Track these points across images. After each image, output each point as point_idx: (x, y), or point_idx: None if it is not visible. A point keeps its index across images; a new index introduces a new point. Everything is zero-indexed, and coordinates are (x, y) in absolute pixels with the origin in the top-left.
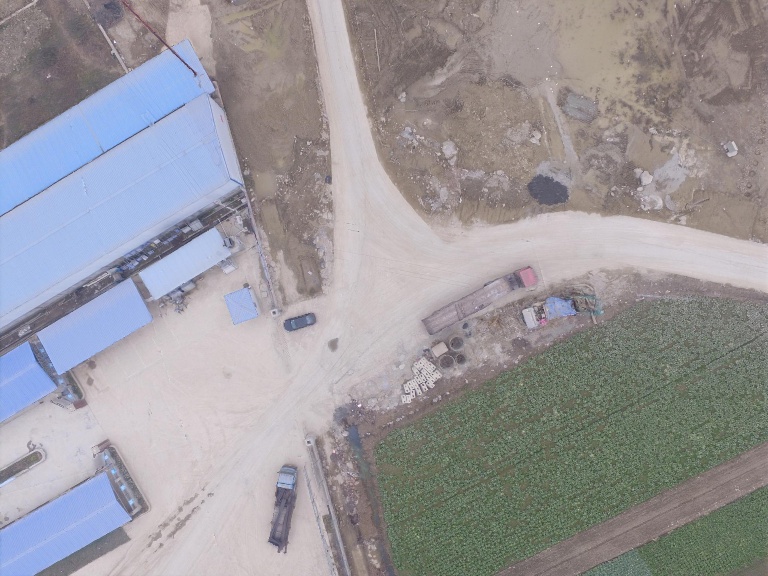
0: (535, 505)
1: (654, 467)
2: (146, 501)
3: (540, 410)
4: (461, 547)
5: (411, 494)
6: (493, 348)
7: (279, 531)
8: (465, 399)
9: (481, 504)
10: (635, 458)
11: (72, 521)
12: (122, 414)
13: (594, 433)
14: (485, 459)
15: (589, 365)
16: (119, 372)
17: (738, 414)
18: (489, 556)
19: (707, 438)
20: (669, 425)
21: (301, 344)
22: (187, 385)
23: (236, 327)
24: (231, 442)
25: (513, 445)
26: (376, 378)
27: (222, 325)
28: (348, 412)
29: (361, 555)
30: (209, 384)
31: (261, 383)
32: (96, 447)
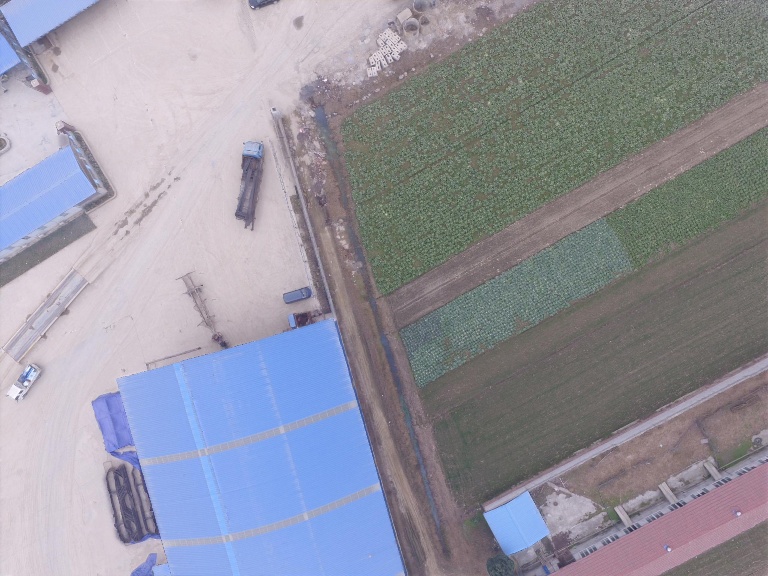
0: (502, 176)
1: (619, 132)
2: (112, 186)
3: (505, 80)
4: (429, 223)
5: (378, 170)
6: (457, 17)
7: (246, 206)
8: (431, 72)
9: (448, 177)
10: (600, 124)
11: (35, 192)
12: (87, 100)
13: (559, 101)
14: (451, 131)
15: (553, 32)
16: (84, 58)
17: (701, 74)
18: (457, 231)
19: (671, 100)
20: (633, 89)
21: (266, 23)
22: (153, 68)
23: (201, 8)
24: (197, 125)
25: (479, 116)
26: (342, 54)
27: (187, 7)
28: (314, 90)
29: (329, 237)
30: (175, 67)
31: (227, 64)
32: (60, 122)
